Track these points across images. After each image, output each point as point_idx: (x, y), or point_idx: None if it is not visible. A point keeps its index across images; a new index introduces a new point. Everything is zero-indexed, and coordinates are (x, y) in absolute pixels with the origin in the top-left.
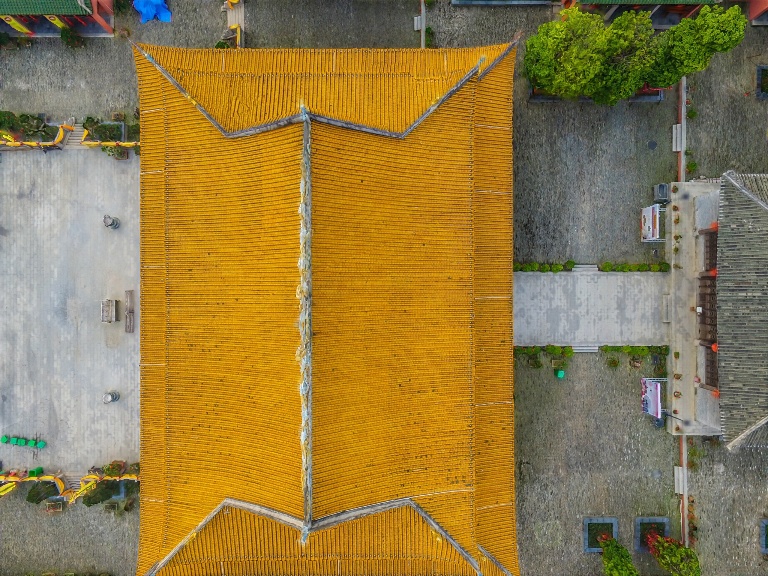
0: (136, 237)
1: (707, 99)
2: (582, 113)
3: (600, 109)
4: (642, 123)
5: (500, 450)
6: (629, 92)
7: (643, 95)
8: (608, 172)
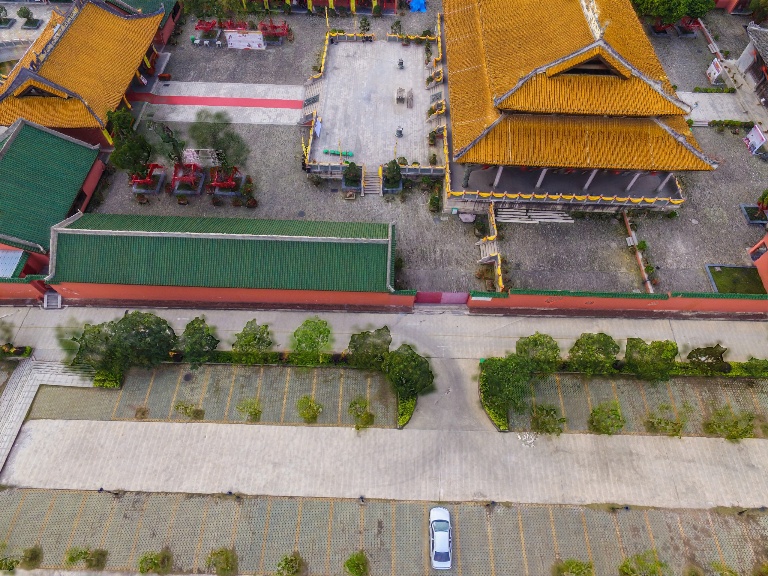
0: (413, 73)
1: (721, 35)
2: (655, 40)
3: (664, 39)
4: (690, 44)
5: None
6: (682, 11)
7: (686, 34)
8: (679, 60)
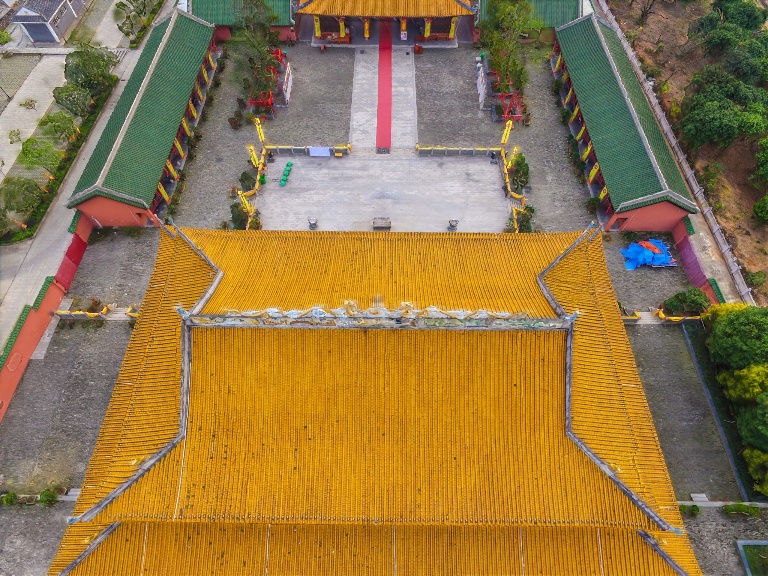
0: None
1: None
2: None
3: None
4: None
5: (209, 575)
6: None
7: None
8: None
